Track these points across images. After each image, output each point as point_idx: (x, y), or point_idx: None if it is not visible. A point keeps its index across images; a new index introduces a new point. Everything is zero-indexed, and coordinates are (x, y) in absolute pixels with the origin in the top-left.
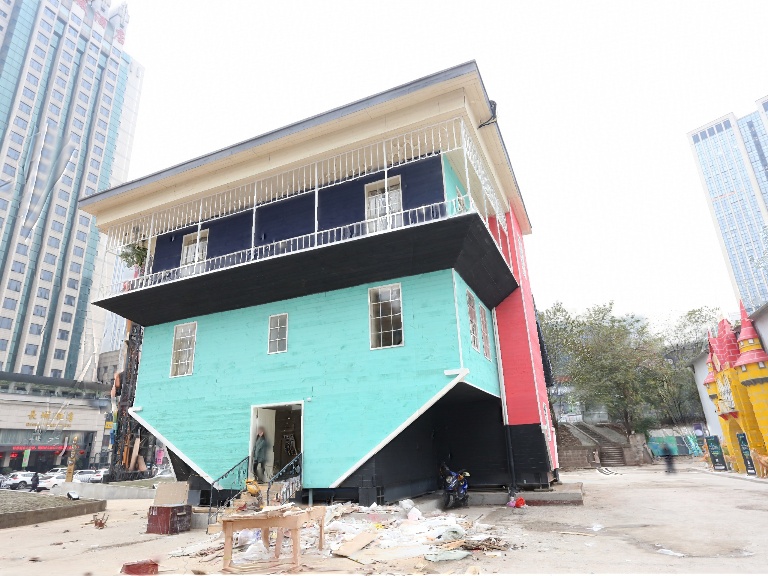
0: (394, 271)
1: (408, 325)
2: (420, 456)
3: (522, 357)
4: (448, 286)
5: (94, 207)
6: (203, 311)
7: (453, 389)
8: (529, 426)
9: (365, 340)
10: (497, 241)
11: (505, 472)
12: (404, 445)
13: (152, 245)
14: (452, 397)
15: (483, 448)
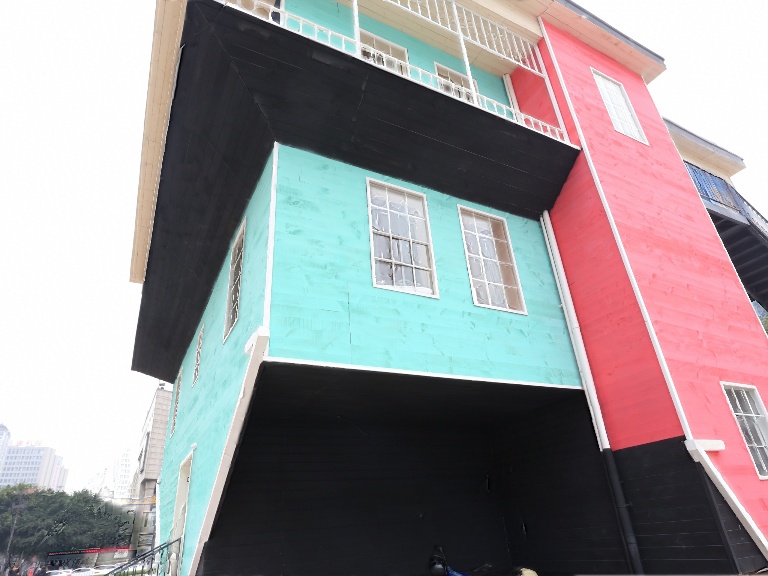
0: (232, 200)
1: (243, 280)
2: (431, 532)
3: (612, 288)
4: (270, 179)
5: (137, 276)
6: (180, 351)
7: (352, 385)
8: (659, 446)
9: (223, 330)
10: (534, 97)
11: (626, 570)
12: (354, 514)
13: None
14: (444, 405)
15: (576, 509)
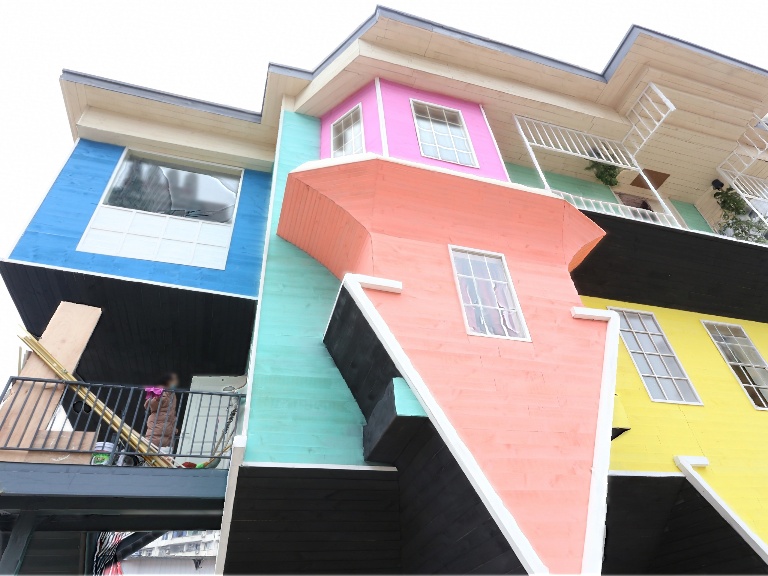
0: None
1: None
2: None
3: None
4: None
5: None
6: None
7: None
8: None
9: None
10: None
11: None
12: None
13: (704, 164)
14: None
15: None
